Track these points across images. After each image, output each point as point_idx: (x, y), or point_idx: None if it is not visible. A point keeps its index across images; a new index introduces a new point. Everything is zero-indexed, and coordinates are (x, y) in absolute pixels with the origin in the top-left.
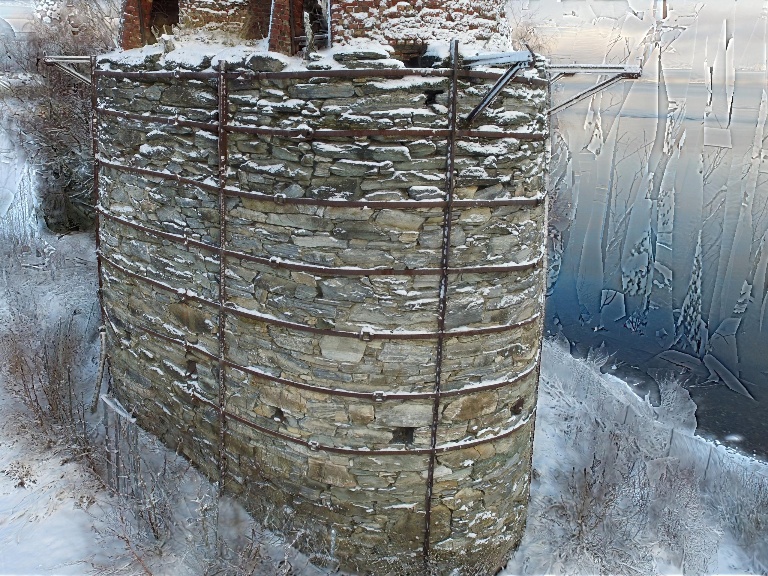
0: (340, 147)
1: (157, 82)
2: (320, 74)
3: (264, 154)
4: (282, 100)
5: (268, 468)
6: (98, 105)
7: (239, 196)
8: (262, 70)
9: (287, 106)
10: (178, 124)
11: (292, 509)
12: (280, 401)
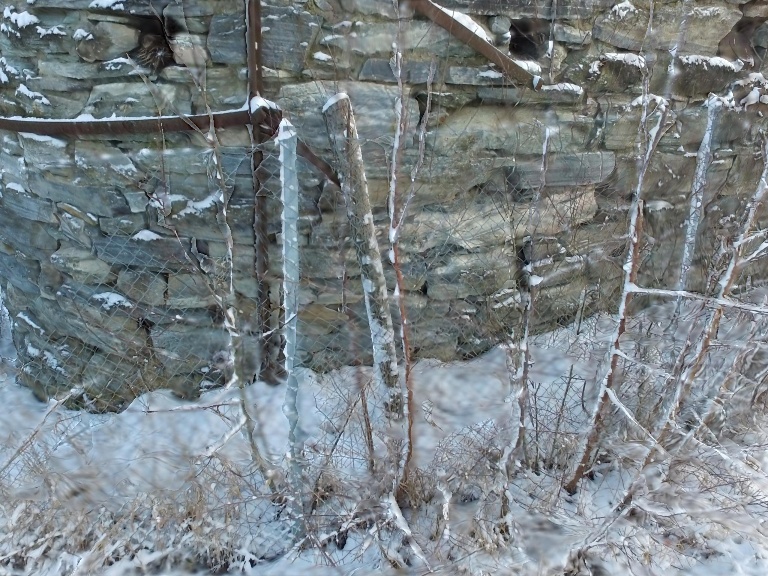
0: None
1: None
2: None
3: None
4: None
5: None
6: None
7: None
8: None
9: None
10: None
11: None
12: None
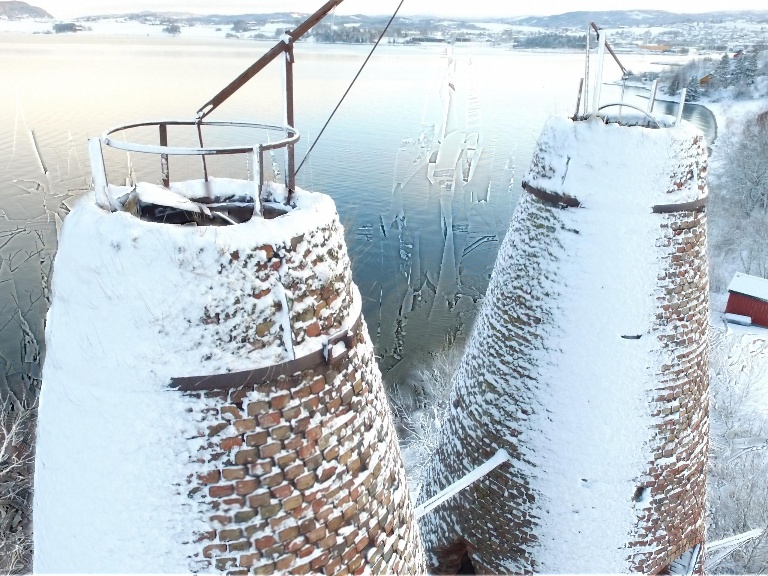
0: None
1: None
2: None
3: None
4: None
5: None
6: None
7: None
8: None
9: None
10: None
11: None
12: None
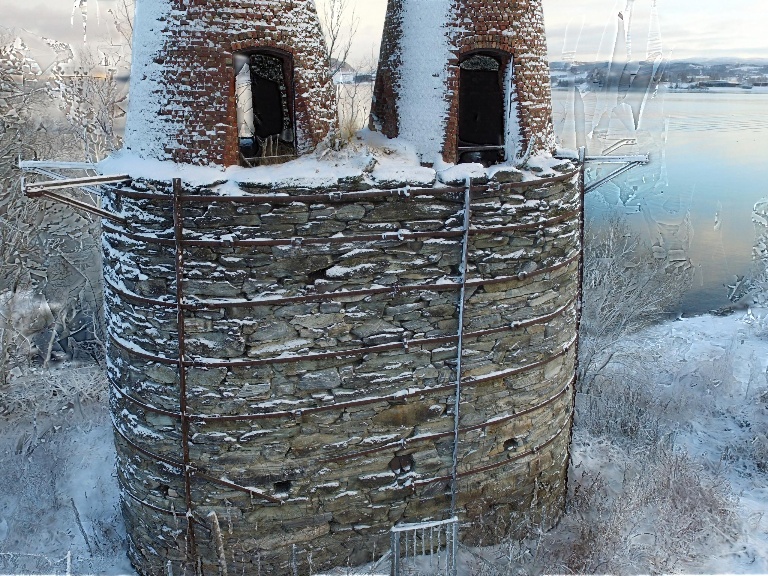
0: (558, 228)
1: (361, 202)
2: (550, 180)
3: (505, 246)
4: (522, 202)
5: (501, 493)
6: (198, 238)
7: (483, 285)
8: (503, 181)
9: (529, 206)
10: (404, 238)
11: (516, 512)
12: (514, 432)
